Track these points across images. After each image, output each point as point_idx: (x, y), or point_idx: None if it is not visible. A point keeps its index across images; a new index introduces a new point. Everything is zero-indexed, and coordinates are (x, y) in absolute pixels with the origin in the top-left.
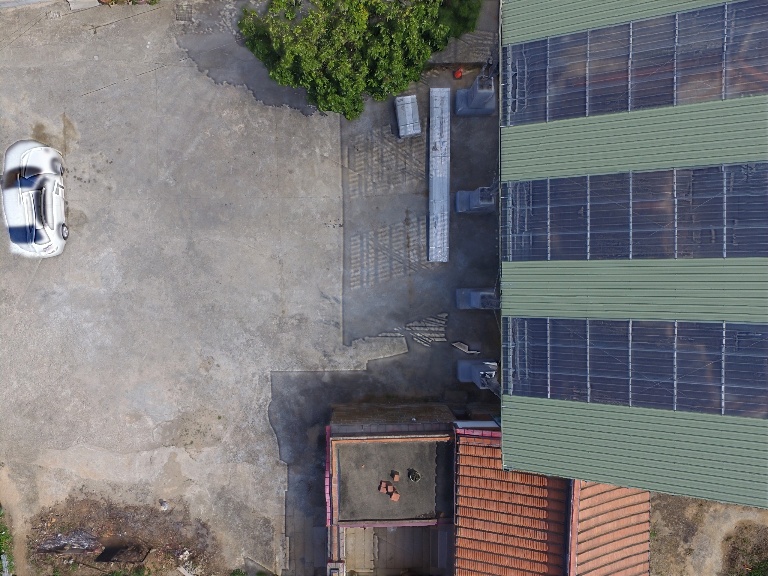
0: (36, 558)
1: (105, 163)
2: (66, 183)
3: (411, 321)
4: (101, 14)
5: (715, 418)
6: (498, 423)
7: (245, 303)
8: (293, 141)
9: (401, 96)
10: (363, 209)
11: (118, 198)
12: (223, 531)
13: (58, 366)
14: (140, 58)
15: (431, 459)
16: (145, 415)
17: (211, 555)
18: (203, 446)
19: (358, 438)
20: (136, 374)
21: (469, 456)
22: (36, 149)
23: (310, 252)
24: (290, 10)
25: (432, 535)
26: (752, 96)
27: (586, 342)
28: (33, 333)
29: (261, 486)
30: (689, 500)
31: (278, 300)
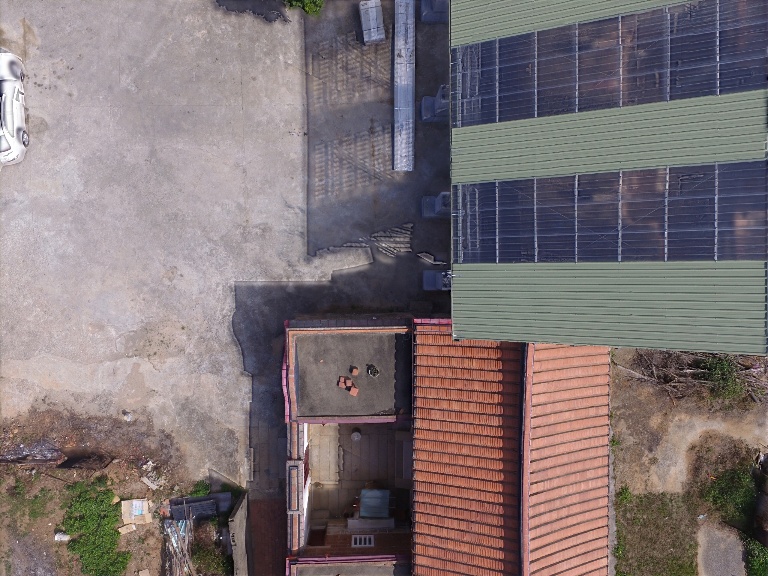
0: None
1: (66, 69)
2: (26, 89)
3: (376, 231)
4: None
5: (658, 265)
6: None
7: (208, 212)
8: (257, 48)
9: (365, 0)
10: (328, 117)
11: (79, 105)
12: (187, 442)
13: (20, 276)
14: None
15: (390, 354)
16: (108, 325)
17: (175, 466)
18: (167, 357)
19: (315, 329)
20: (98, 284)
21: (426, 345)
22: None
23: (274, 161)
24: None
25: (397, 446)
26: None
27: (533, 201)
28: None
29: (225, 397)
30: (654, 409)
31: (242, 209)
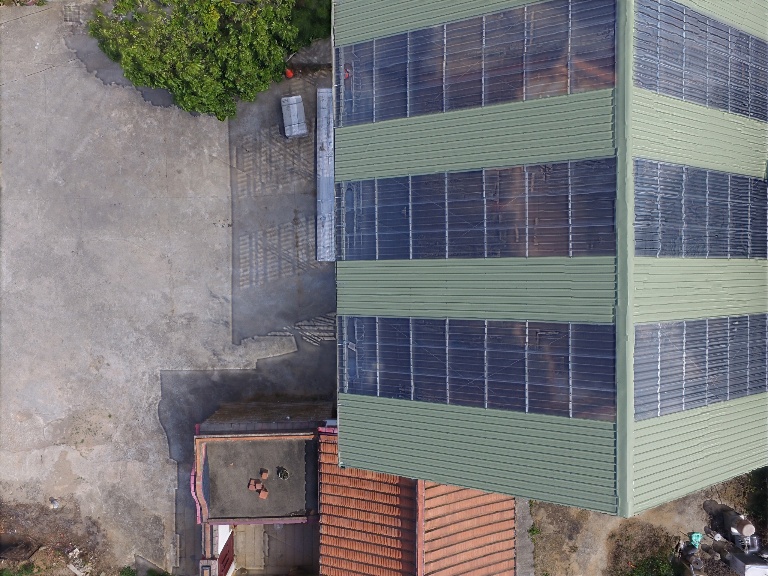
0: None
1: None
2: None
3: (300, 320)
4: None
5: (520, 416)
6: None
7: (134, 302)
8: (181, 141)
9: (287, 97)
10: (252, 209)
11: (7, 198)
12: (114, 529)
13: None
14: (29, 59)
15: (300, 457)
16: (36, 414)
17: (101, 553)
18: (94, 444)
19: (222, 436)
20: (26, 373)
21: (330, 454)
22: None
23: (199, 252)
24: (138, 12)
25: None
26: (549, 97)
27: (409, 341)
28: None
29: (151, 484)
30: None
31: (167, 299)
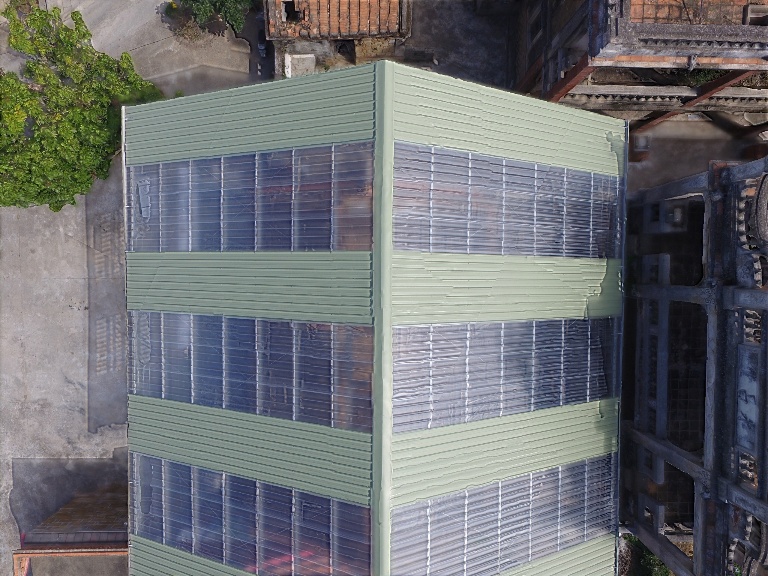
0: None
1: None
2: None
3: None
4: None
5: None
6: None
7: None
8: (36, 219)
9: None
10: (110, 291)
11: None
12: None
13: None
14: None
15: None
16: None
17: None
18: None
19: (42, 551)
20: None
21: None
22: None
23: (54, 335)
24: None
25: None
26: (313, 251)
27: (190, 490)
28: None
29: None
30: None
31: (20, 384)
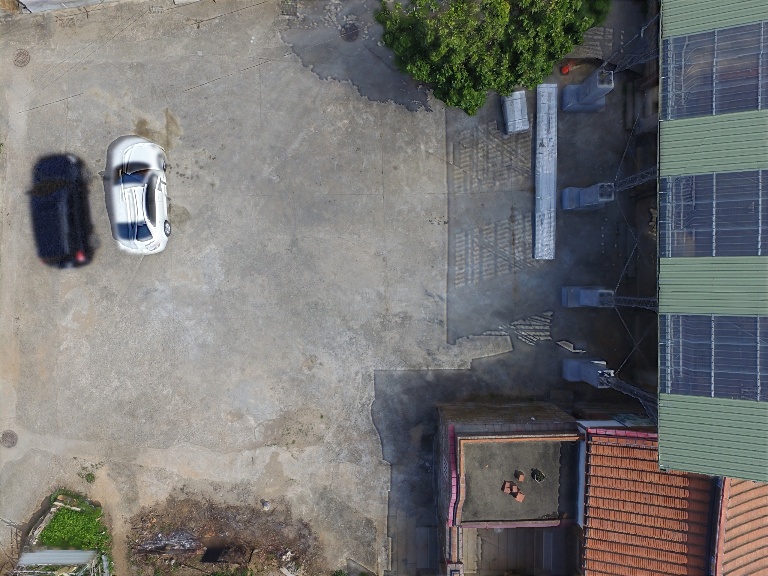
0: (137, 558)
1: (208, 159)
2: (169, 179)
3: (516, 319)
4: (205, 9)
5: None
6: (622, 423)
7: (348, 301)
8: (398, 137)
9: None
10: (468, 206)
11: (221, 194)
12: (325, 532)
13: (159, 364)
14: (244, 53)
15: (555, 459)
16: (247, 414)
17: (313, 556)
18: (305, 445)
19: (486, 437)
20: (238, 372)
21: (601, 456)
22: (138, 145)
23: (414, 249)
24: (434, 2)
25: (536, 536)
26: None
27: (756, 340)
28: (134, 331)
29: (364, 486)
30: None
31: (382, 298)
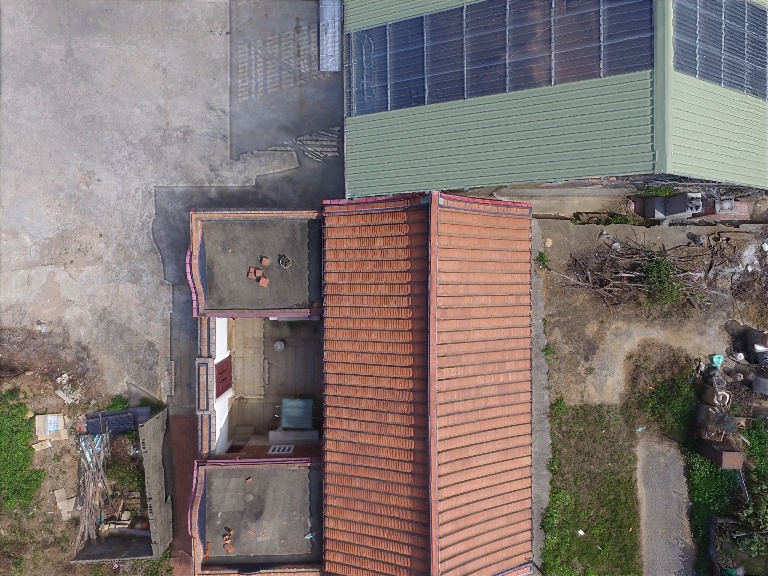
0: None
1: None
2: None
3: (302, 134)
4: None
5: (545, 91)
6: None
7: (127, 114)
8: None
9: None
10: (251, 16)
11: None
12: (105, 354)
13: None
14: None
15: (303, 244)
16: (22, 232)
17: (92, 379)
18: (84, 265)
19: (220, 213)
20: (12, 189)
21: (335, 227)
22: None
23: (195, 61)
24: None
25: None
26: None
27: (423, 40)
28: None
29: (145, 307)
30: (590, 317)
31: (162, 111)
